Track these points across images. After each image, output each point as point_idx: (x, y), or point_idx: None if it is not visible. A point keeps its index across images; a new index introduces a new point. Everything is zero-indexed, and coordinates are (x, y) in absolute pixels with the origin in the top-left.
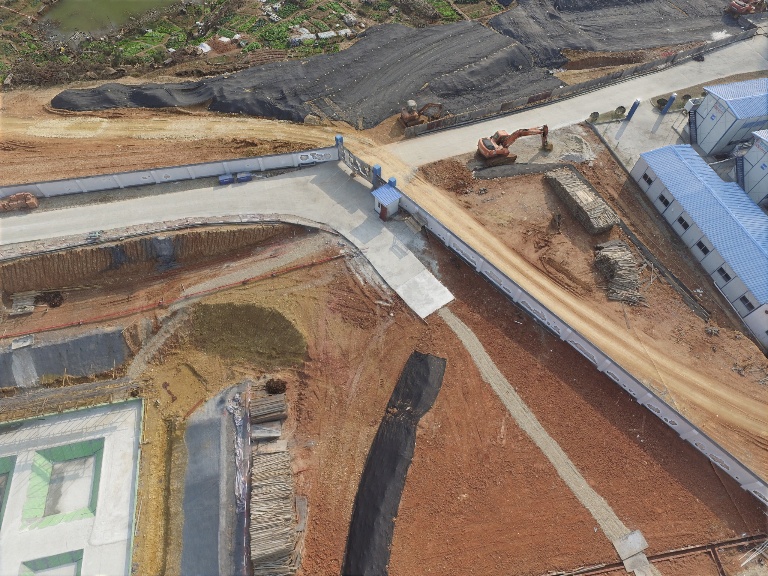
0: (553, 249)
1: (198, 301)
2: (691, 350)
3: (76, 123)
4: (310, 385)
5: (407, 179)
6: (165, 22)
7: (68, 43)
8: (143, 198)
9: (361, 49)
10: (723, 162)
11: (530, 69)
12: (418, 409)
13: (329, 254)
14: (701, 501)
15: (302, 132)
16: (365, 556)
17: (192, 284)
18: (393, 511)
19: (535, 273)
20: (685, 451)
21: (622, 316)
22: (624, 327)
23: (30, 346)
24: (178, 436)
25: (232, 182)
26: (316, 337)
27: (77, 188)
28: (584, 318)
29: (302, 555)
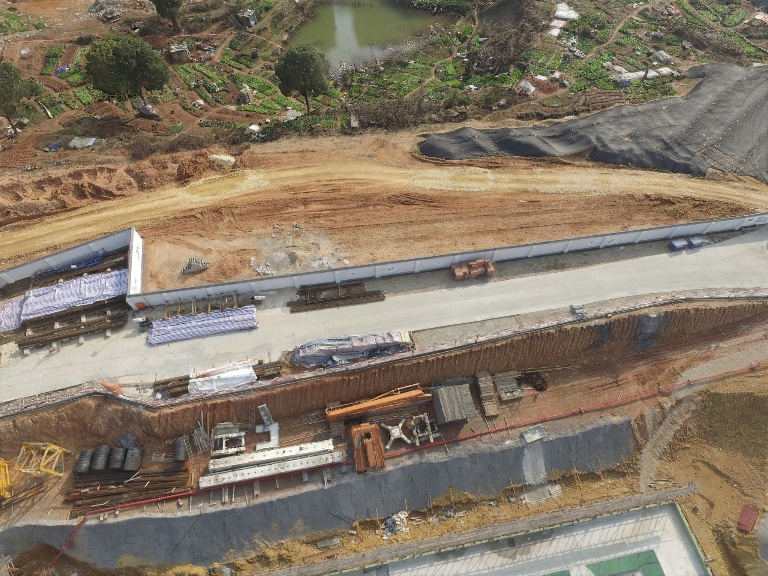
0: None
1: (704, 388)
2: None
3: (458, 173)
4: None
5: None
6: (419, 53)
7: None
8: (599, 266)
9: (712, 92)
10: None
11: None
12: None
13: None
14: None
15: (709, 188)
16: None
17: (685, 367)
18: None
19: None
20: None
21: None
22: None
23: (542, 439)
24: (749, 554)
25: (683, 248)
26: None
27: (524, 253)
28: None
29: None
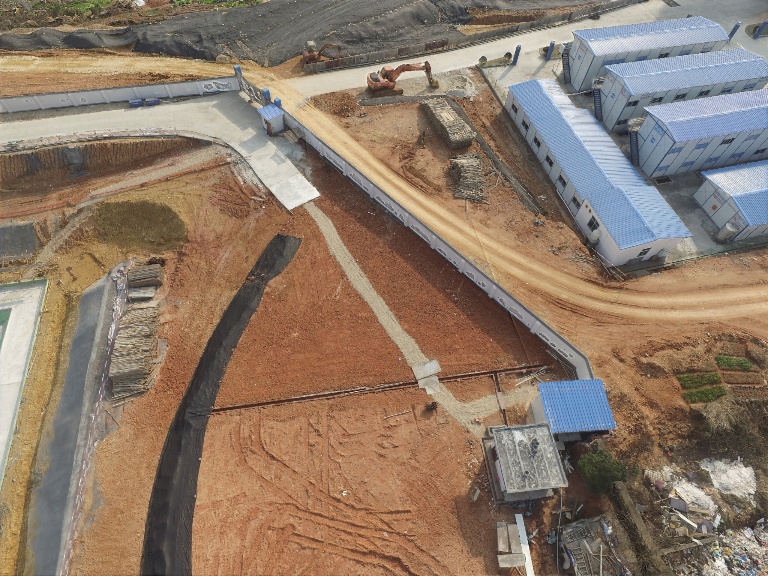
0: (415, 159)
1: (101, 200)
2: (517, 236)
3: (12, 60)
4: (185, 260)
5: (298, 105)
6: None
7: (23, 5)
8: (60, 117)
9: (279, 3)
10: (590, 98)
11: (436, 24)
12: (270, 274)
13: (217, 161)
14: (494, 341)
15: (213, 69)
16: (204, 375)
17: (98, 188)
18: (233, 344)
19: (395, 178)
20: (491, 307)
21: (463, 210)
22: (463, 218)
23: None
24: (73, 305)
25: (141, 105)
26: (196, 224)
27: (3, 108)
28: (429, 211)
29: (156, 379)
